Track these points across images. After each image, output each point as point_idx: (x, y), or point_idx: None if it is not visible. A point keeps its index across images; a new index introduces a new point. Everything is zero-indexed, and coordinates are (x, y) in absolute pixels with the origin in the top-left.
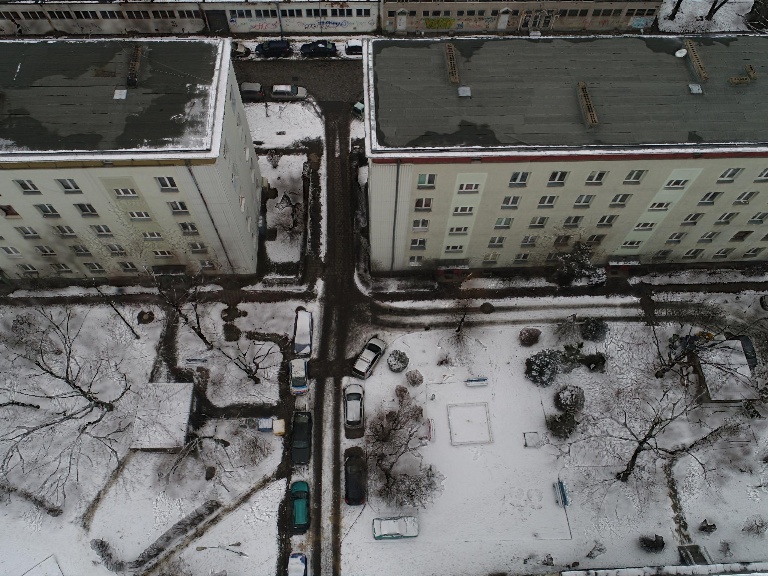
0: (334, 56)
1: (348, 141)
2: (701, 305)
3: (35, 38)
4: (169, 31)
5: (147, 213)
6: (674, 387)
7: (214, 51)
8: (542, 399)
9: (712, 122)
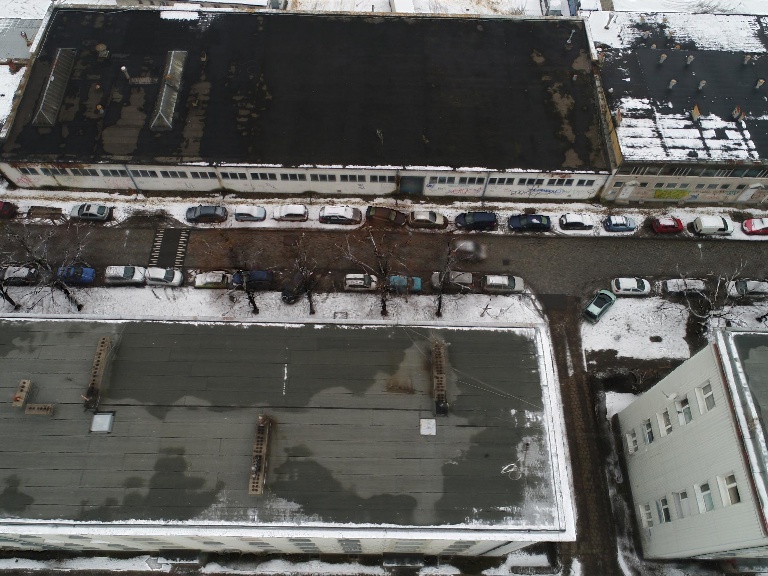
0: (547, 231)
1: (581, 353)
2: None
3: (199, 195)
4: (353, 192)
5: None
6: None
7: (532, 349)
8: None
9: None
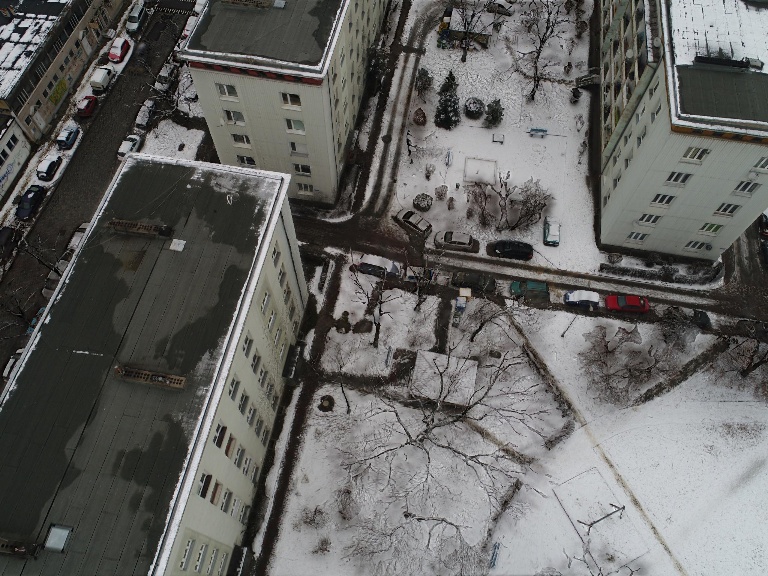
0: (46, 192)
1: None
2: (416, 24)
3: None
4: None
5: (272, 311)
6: (473, 56)
7: (144, 164)
8: (469, 125)
9: None
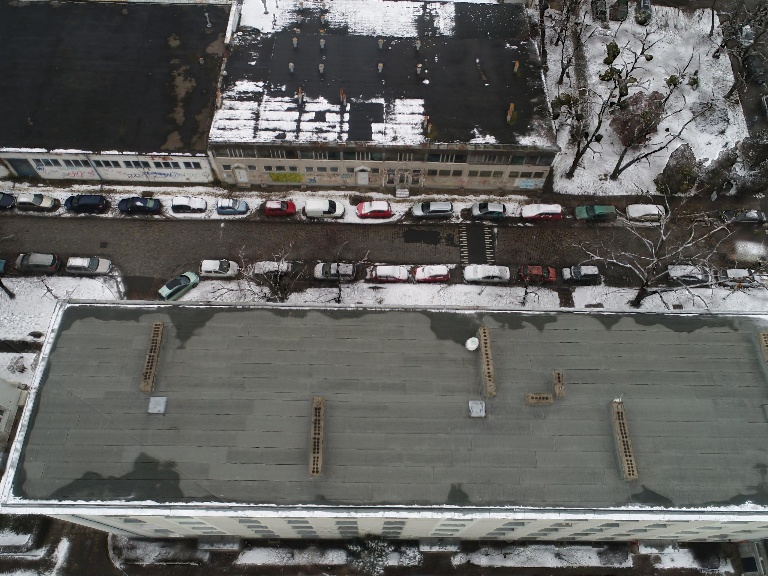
0: (157, 214)
1: None
2: None
3: None
4: None
5: None
6: None
7: None
8: None
9: (488, 468)
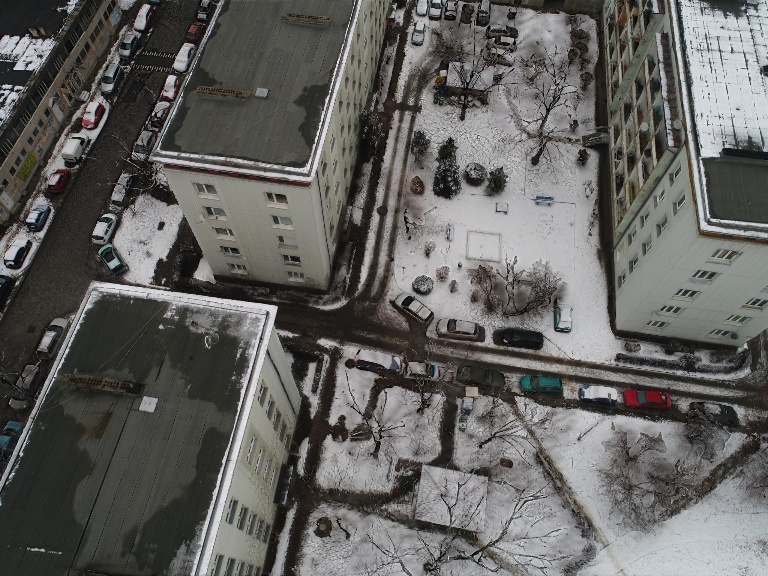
0: (15, 282)
1: None
2: (410, 77)
3: None
4: None
5: None
6: (472, 113)
7: (111, 298)
8: (470, 193)
9: None
